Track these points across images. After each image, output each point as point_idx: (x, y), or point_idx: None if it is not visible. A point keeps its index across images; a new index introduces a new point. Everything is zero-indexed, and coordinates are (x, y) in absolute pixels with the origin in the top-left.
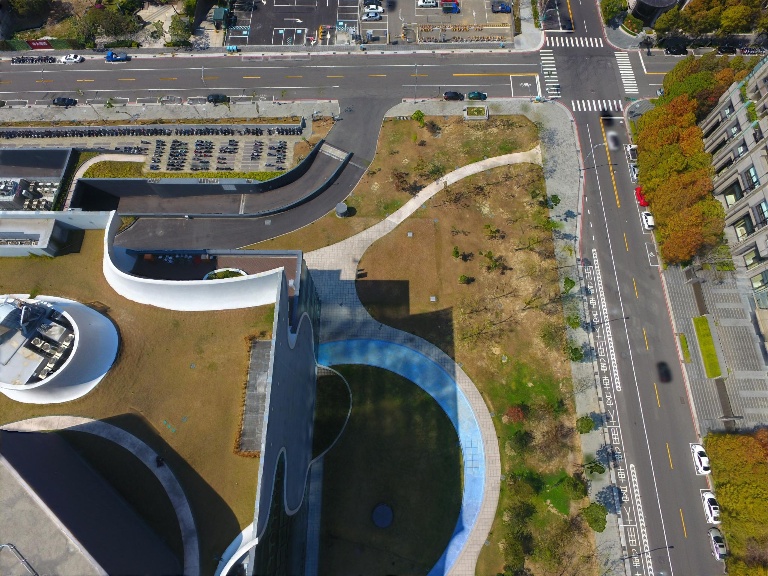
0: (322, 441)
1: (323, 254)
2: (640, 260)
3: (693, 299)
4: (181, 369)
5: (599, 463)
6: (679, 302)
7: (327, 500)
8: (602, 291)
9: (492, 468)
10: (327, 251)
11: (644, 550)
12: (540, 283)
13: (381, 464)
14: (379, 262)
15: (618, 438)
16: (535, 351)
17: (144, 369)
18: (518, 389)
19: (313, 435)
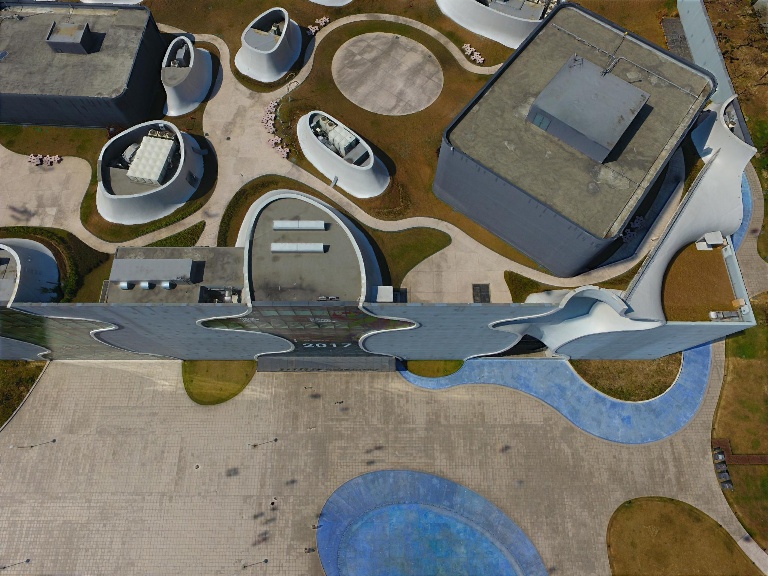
0: None
1: None
2: None
3: None
4: None
5: None
6: None
7: None
8: None
9: (755, 186)
10: None
11: None
12: (764, 68)
13: None
14: None
15: None
16: None
17: None
18: (763, 137)
19: None
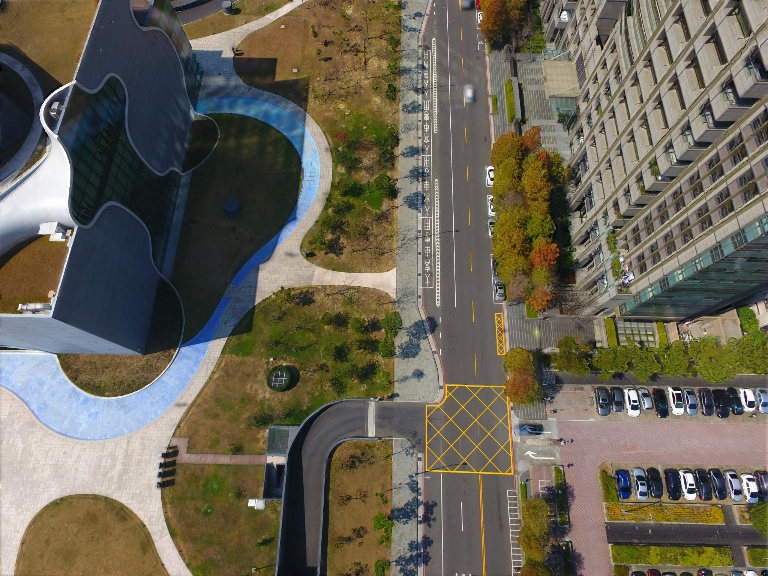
0: (191, 161)
1: (209, 40)
2: (470, 46)
3: (508, 72)
4: (47, 21)
5: (410, 178)
6: (497, 75)
7: (191, 199)
8: (435, 67)
9: (325, 181)
10: (213, 38)
11: (435, 232)
12: (384, 60)
13: (237, 177)
14: (255, 45)
15: (429, 163)
16: (372, 106)
17: (20, 21)
18: (354, 131)
19: (185, 157)
